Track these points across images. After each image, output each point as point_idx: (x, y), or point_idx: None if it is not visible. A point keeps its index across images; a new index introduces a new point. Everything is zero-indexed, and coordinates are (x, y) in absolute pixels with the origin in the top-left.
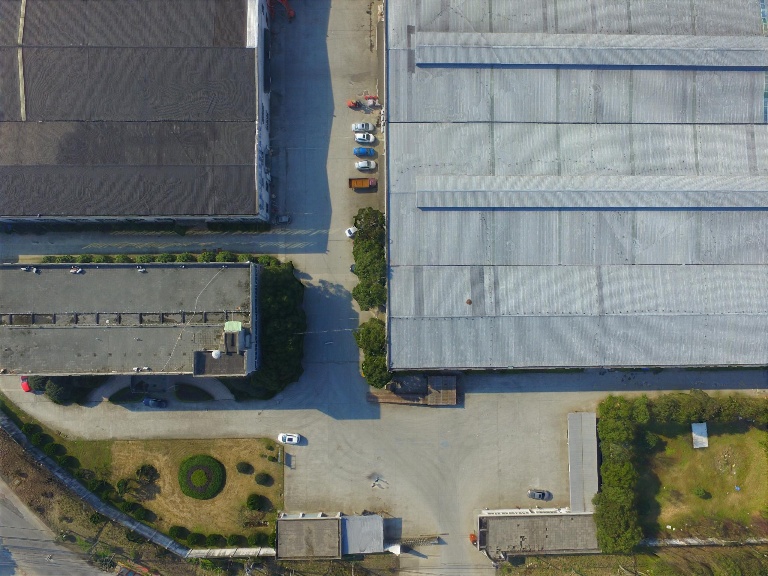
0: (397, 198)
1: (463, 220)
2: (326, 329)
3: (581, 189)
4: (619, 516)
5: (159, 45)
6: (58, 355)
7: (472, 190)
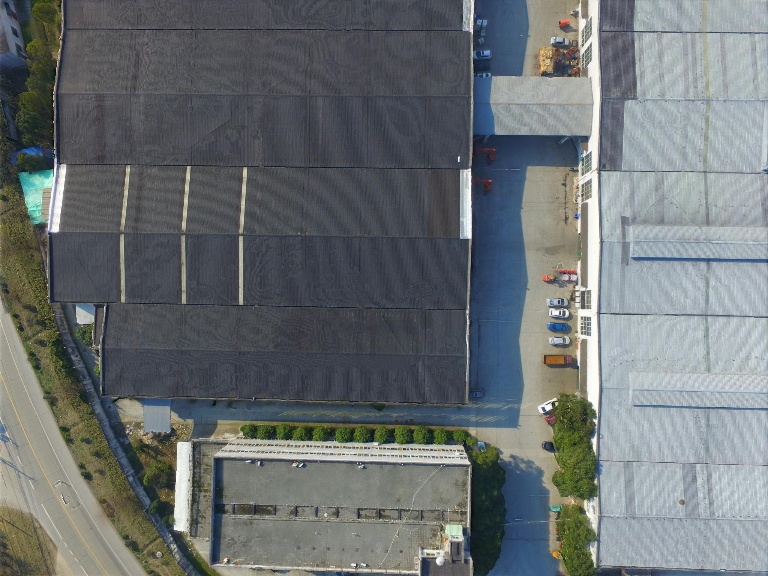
0: (610, 393)
1: (677, 417)
2: (516, 505)
3: None
4: None
5: (374, 235)
6: (279, 547)
7: (690, 390)
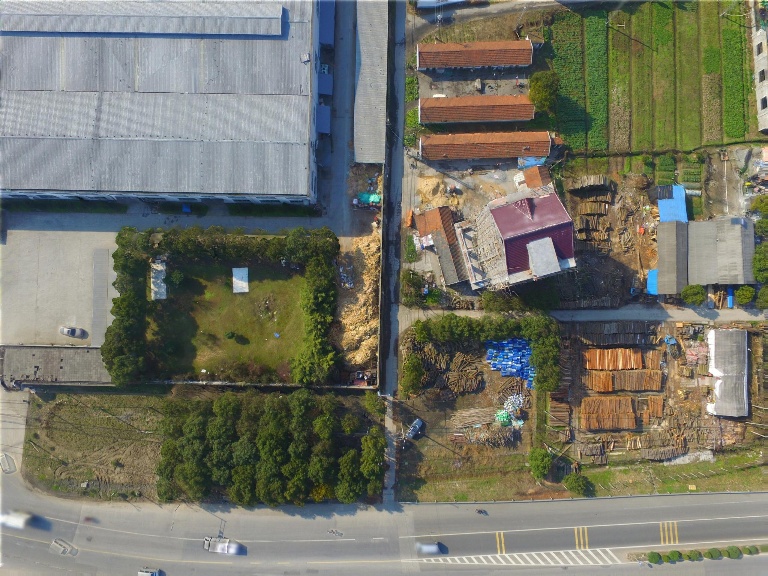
0: None
1: None
2: None
3: (76, 13)
4: (112, 342)
5: None
6: None
7: None
